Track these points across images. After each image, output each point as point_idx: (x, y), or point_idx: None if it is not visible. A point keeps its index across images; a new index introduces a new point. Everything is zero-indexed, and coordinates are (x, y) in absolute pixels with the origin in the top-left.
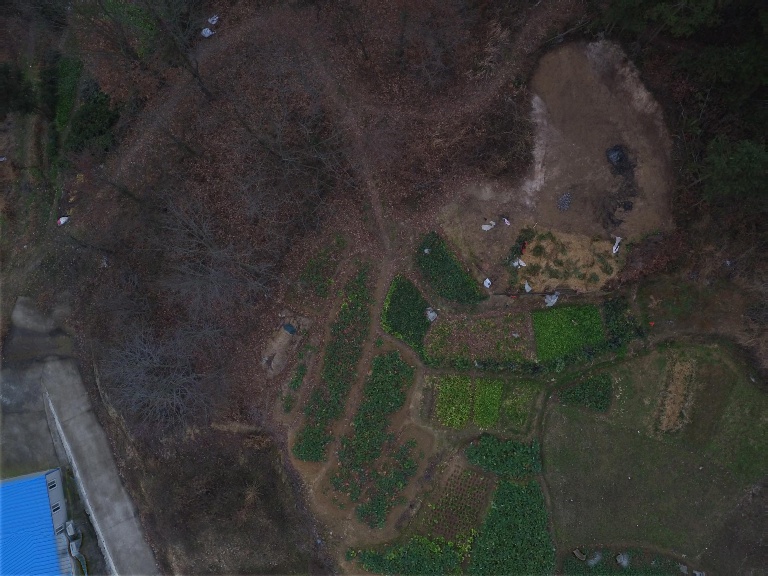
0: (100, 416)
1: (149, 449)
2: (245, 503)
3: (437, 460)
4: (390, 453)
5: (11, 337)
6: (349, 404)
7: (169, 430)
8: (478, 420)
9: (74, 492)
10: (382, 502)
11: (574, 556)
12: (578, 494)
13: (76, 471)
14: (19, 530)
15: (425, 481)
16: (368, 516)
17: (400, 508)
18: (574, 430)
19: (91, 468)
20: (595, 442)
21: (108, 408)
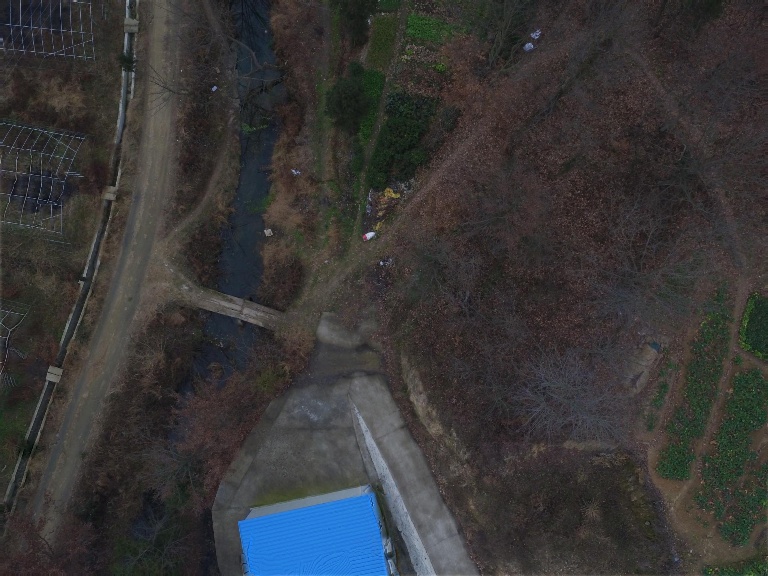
0: (414, 433)
1: (486, 467)
2: (582, 520)
3: None
4: (749, 471)
5: (317, 353)
6: (711, 423)
7: (515, 448)
8: None
9: (387, 509)
10: (747, 520)
11: None
12: None
13: (394, 488)
14: (351, 548)
15: None
16: (732, 534)
17: (760, 526)
18: None
19: (410, 485)
20: None
21: (429, 425)
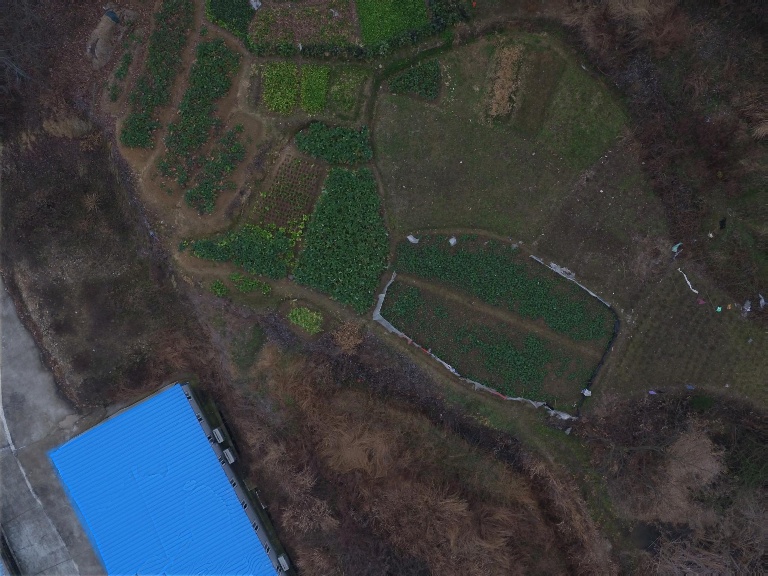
0: None
1: None
2: (87, 215)
3: (266, 147)
4: (218, 140)
5: None
6: (175, 91)
7: (5, 138)
8: (305, 105)
9: None
10: (209, 185)
11: (407, 241)
12: (410, 180)
13: None
14: None
15: (254, 168)
16: (196, 200)
17: (230, 194)
18: (404, 117)
19: None
20: (425, 126)
21: None
